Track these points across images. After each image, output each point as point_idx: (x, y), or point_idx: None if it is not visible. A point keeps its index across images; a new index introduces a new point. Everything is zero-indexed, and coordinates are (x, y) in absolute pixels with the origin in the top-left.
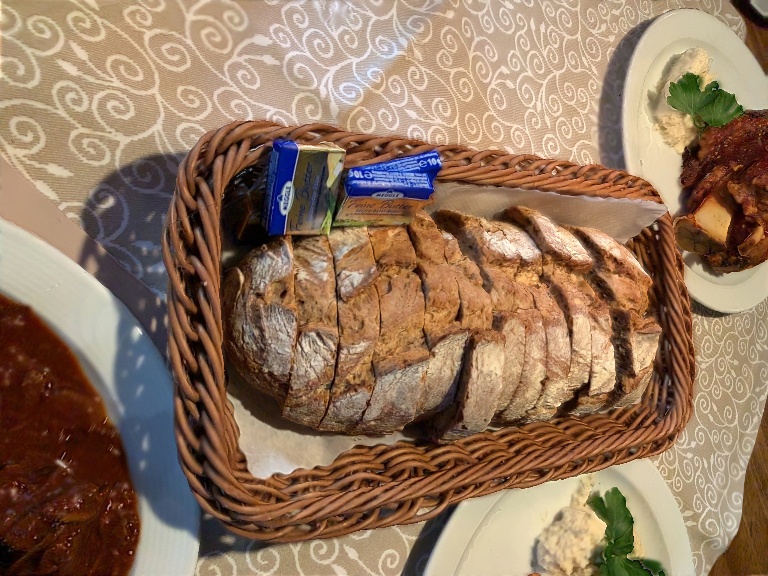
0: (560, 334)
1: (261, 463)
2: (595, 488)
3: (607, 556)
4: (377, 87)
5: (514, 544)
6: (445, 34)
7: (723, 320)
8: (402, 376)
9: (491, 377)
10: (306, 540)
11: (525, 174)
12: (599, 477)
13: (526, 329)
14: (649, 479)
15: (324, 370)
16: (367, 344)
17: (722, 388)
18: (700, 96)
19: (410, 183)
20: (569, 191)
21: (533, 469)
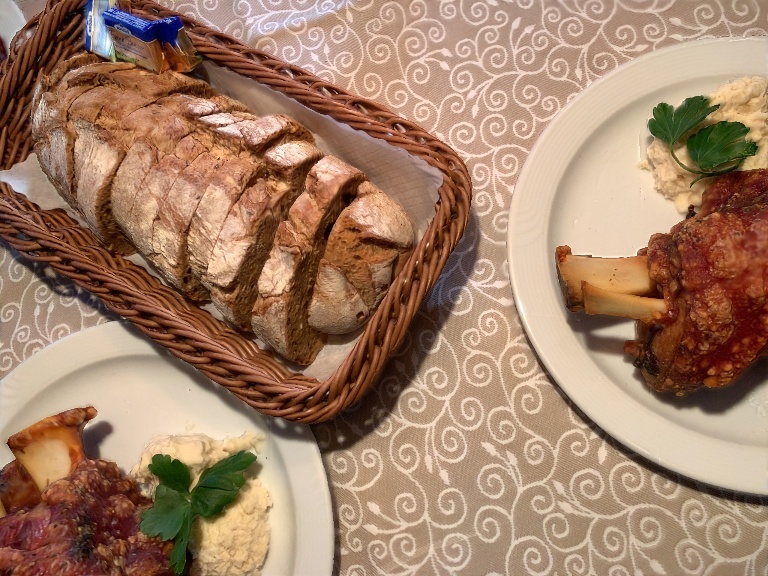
0: (190, 191)
1: (11, 176)
2: (260, 458)
3: (154, 462)
4: (294, 29)
5: (146, 418)
6: (387, 7)
7: (653, 478)
8: (58, 141)
9: (97, 171)
10: (42, 280)
11: (279, 77)
12: (268, 449)
13: (156, 164)
14: (312, 500)
15: (41, 123)
16: (57, 112)
17: (595, 574)
18: (690, 122)
19: (133, 23)
20: (321, 109)
21: (124, 300)
